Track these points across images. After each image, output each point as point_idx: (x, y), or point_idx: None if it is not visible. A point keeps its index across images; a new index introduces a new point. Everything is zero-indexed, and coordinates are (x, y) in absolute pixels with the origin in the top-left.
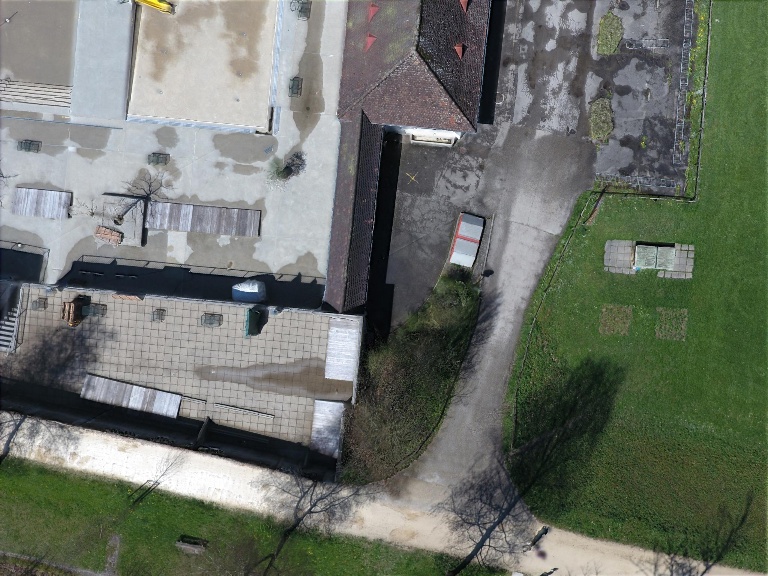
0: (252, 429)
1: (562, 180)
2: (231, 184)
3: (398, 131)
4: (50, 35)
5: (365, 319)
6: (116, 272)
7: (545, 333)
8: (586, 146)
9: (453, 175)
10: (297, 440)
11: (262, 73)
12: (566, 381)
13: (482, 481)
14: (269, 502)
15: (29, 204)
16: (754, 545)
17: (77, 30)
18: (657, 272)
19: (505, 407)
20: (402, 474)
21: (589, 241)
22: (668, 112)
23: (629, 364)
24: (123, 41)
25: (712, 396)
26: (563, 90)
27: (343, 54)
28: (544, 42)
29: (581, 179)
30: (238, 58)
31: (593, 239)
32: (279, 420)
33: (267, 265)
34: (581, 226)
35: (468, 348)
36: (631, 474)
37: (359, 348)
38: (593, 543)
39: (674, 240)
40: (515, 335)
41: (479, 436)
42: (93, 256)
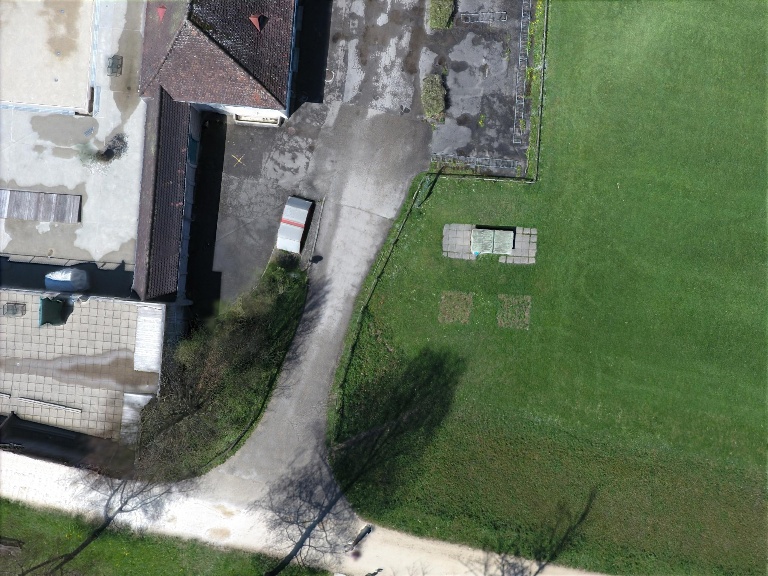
0: (59, 424)
1: (396, 161)
2: (50, 168)
3: (217, 110)
4: None
5: (179, 308)
6: None
7: (379, 322)
8: (421, 125)
9: (281, 157)
10: (106, 435)
11: (81, 51)
12: (403, 372)
13: (302, 477)
14: (77, 501)
15: None
16: (591, 543)
17: None
18: (498, 257)
19: (331, 400)
20: (217, 471)
21: (425, 225)
22: (507, 89)
23: (470, 354)
24: None
25: (558, 387)
26: (396, 67)
27: None
28: (375, 16)
29: (416, 160)
30: (56, 36)
31: (430, 223)
32: (87, 415)
33: (89, 253)
34: (416, 209)
35: (293, 338)
36: (467, 469)
37: (162, 338)
38: (419, 542)
39: (515, 223)
40: (344, 324)
41: (301, 430)
42: None
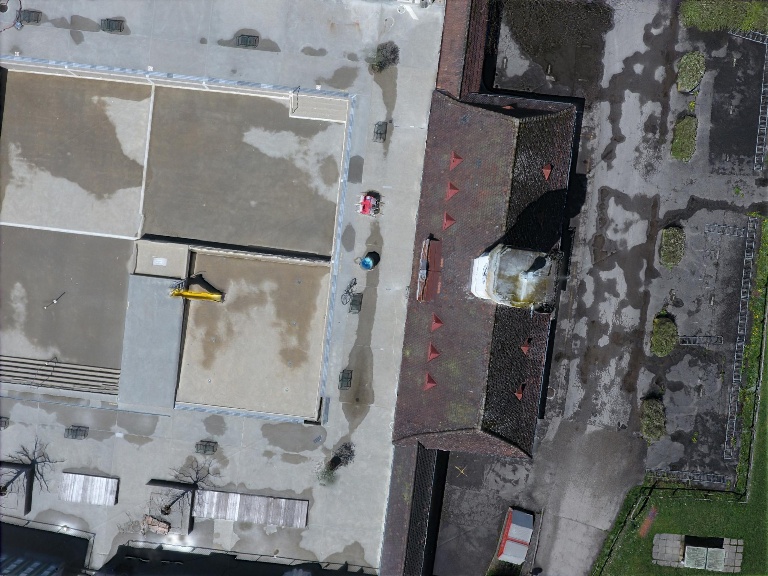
0: None
1: (612, 475)
2: (279, 473)
3: None
4: (97, 316)
5: None
6: (162, 558)
7: None
8: (637, 441)
9: (502, 469)
10: None
11: (311, 363)
12: None
13: None
14: None
15: (75, 490)
16: None
17: (126, 317)
18: None
19: None
20: None
21: (638, 536)
22: (720, 408)
23: None
24: (172, 331)
25: None
26: (615, 385)
27: (399, 379)
28: (597, 338)
29: (631, 474)
30: (287, 347)
31: (642, 534)
32: None
33: (314, 554)
34: (630, 522)
35: None
36: None
37: None
38: None
39: (723, 535)
40: None
41: None
42: (139, 541)
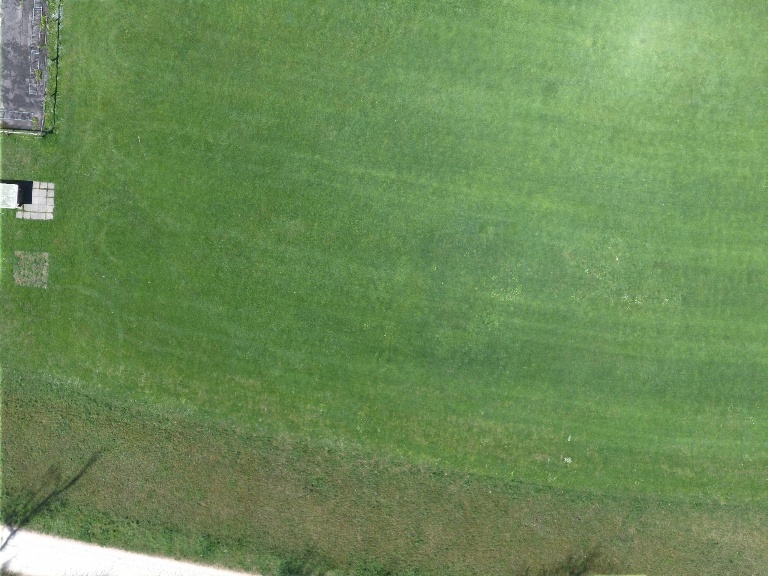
0: None
1: None
2: None
3: None
4: None
5: None
6: None
7: None
8: None
9: None
10: None
11: None
12: None
13: None
14: None
15: None
16: (70, 509)
17: None
18: (15, 213)
19: None
20: None
21: None
22: (22, 38)
23: None
24: None
25: (79, 349)
26: None
27: None
28: None
29: None
30: None
31: None
32: None
33: None
34: None
35: None
36: None
37: None
38: None
39: (31, 178)
40: None
41: None
42: None
